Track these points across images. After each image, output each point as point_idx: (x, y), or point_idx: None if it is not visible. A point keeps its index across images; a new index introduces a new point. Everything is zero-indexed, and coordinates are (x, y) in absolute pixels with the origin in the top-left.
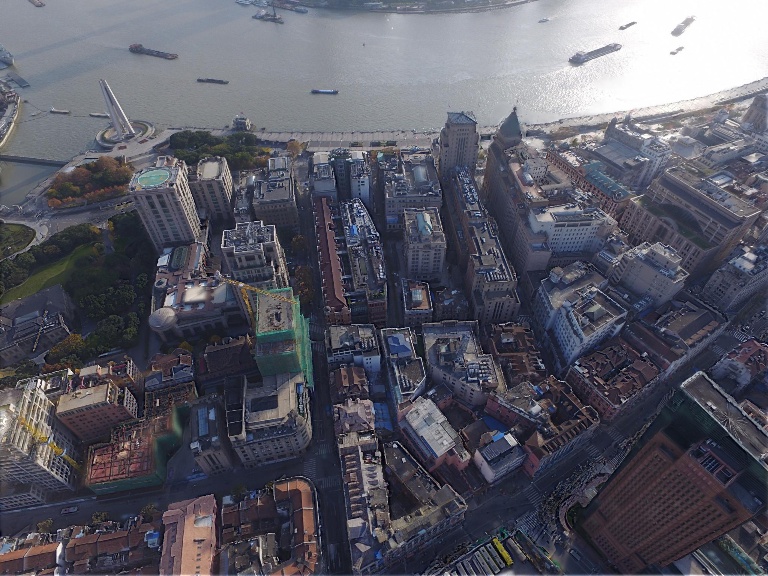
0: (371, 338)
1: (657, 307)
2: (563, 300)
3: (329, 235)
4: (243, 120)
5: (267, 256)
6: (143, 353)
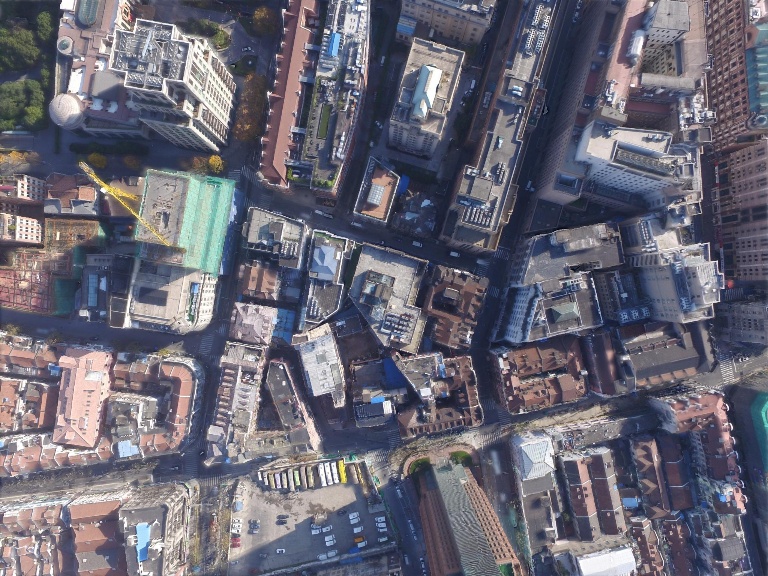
0: (296, 242)
1: (651, 319)
2: (543, 275)
3: (298, 38)
4: None
5: (179, 91)
6: (54, 143)
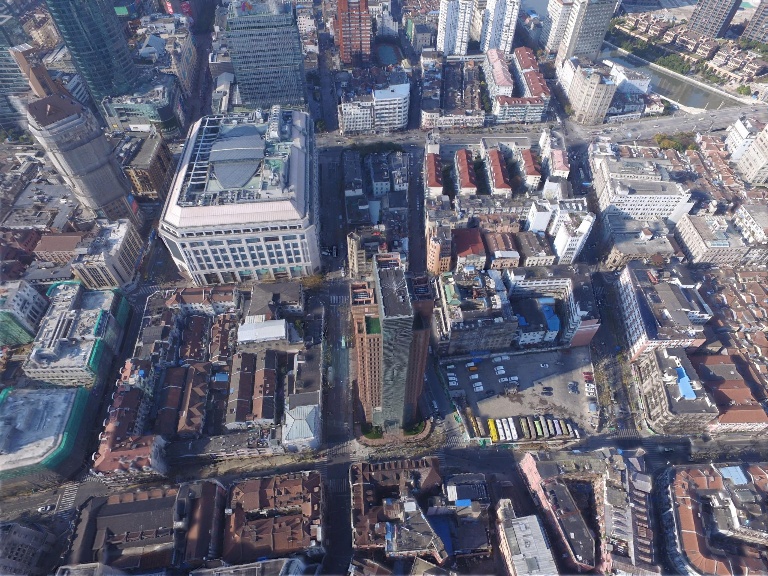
0: None
1: (128, 573)
2: None
3: None
4: None
5: None
6: None
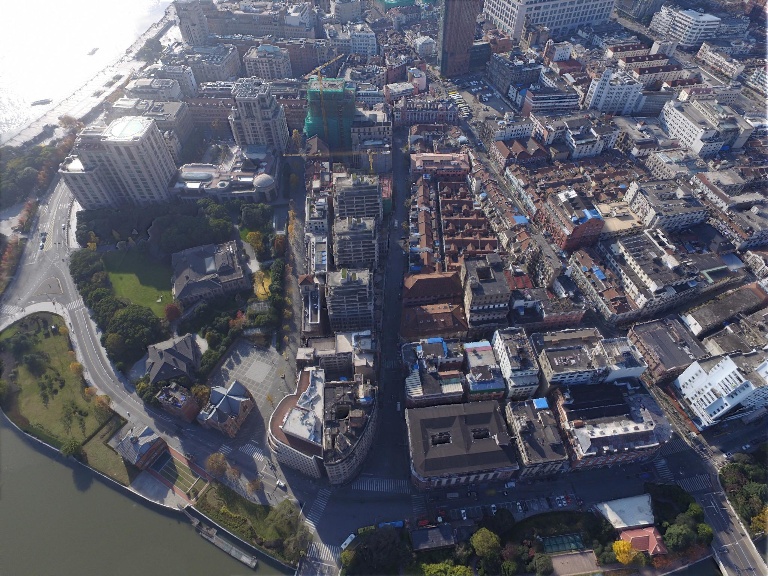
0: None
1: None
2: (346, 36)
3: None
4: None
5: None
6: (281, 209)
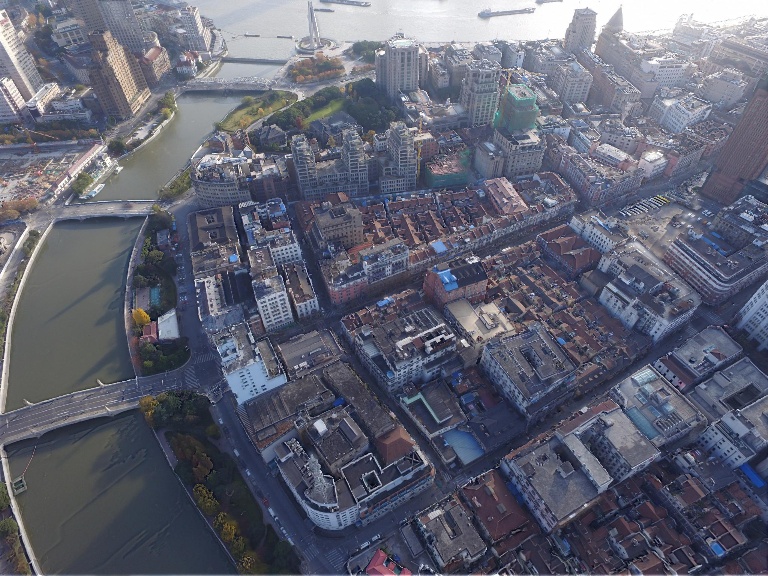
0: None
1: (727, 107)
2: (671, 103)
3: None
4: (402, 34)
5: None
6: None
